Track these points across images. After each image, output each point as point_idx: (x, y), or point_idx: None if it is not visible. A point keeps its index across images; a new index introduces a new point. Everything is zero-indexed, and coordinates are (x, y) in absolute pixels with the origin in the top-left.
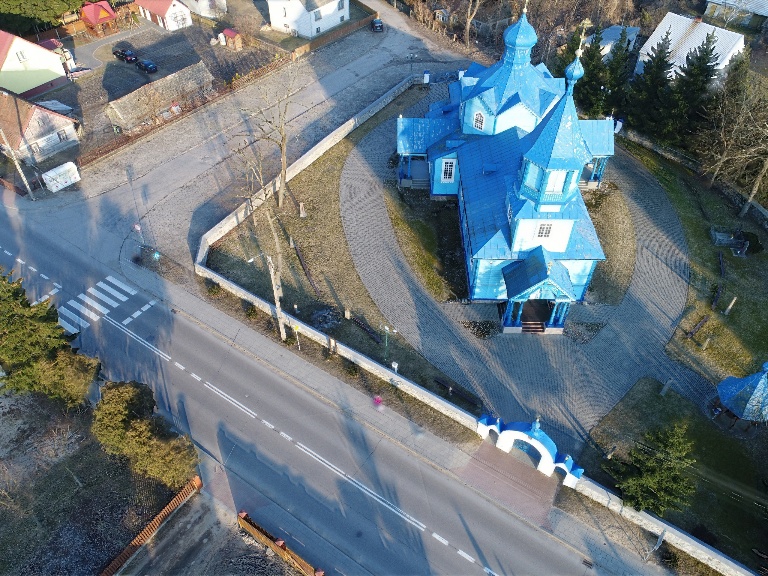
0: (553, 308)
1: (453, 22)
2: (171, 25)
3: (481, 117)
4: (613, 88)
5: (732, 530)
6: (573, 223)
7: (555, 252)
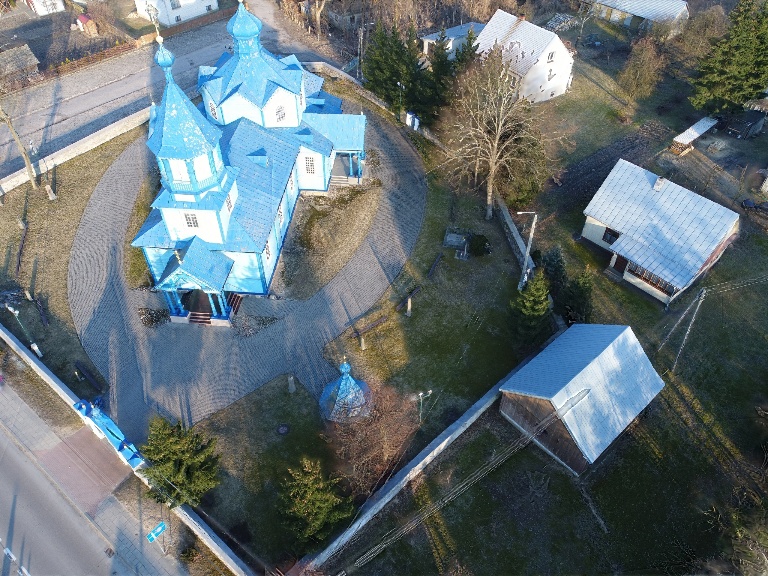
0: (235, 300)
1: None
2: (40, 10)
3: (213, 107)
4: (408, 84)
5: (272, 530)
6: (216, 214)
7: (213, 243)
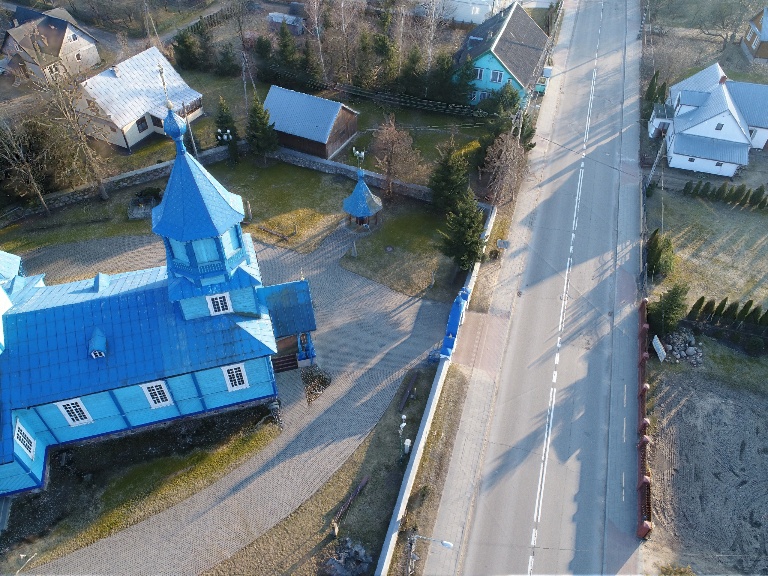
0: None
1: None
2: None
3: None
4: None
5: None
6: None
7: None
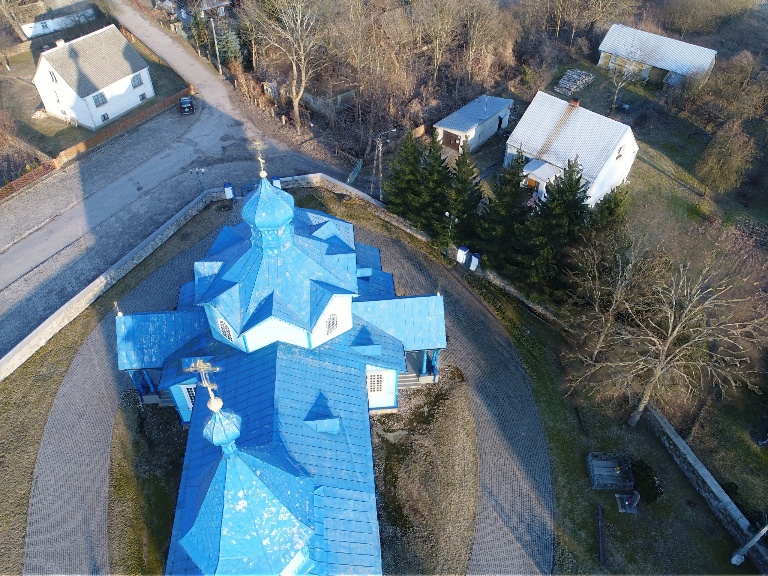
0: None
1: (286, 96)
2: None
3: (226, 327)
4: (461, 214)
5: None
6: None
7: None
